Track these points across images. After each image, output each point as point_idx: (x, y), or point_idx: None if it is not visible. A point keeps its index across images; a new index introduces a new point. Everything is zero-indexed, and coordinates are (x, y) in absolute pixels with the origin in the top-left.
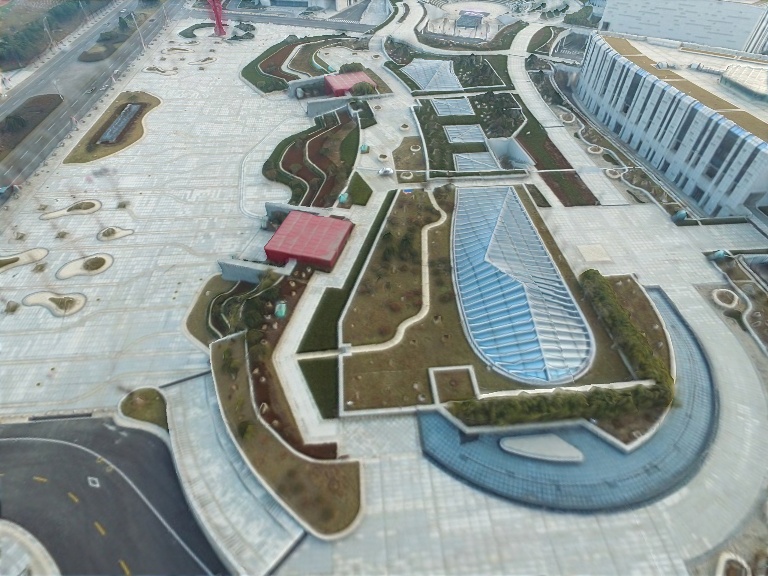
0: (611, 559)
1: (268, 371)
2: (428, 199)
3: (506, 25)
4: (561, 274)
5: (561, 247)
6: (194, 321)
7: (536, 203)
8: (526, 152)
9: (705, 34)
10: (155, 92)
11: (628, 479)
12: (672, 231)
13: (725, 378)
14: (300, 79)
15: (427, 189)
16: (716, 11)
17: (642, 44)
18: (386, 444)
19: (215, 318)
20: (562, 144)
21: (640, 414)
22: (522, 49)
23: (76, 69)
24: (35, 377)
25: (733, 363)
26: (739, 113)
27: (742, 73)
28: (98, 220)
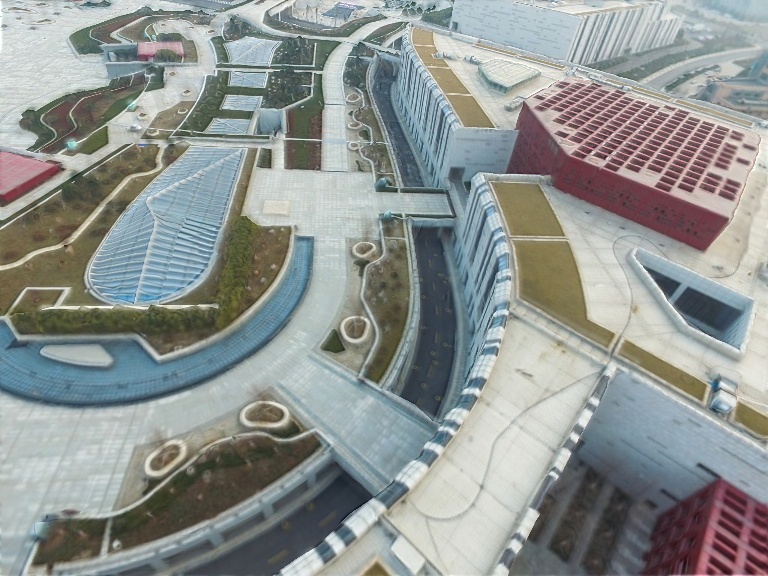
0: (68, 442)
1: None
2: (155, 153)
3: (362, 17)
4: (226, 221)
5: (247, 200)
6: None
7: (257, 164)
8: (286, 122)
9: (535, 39)
10: None
11: (141, 383)
12: (367, 195)
13: (306, 311)
14: None
15: (162, 145)
16: (542, 18)
17: (445, 38)
18: None
19: None
20: (329, 119)
21: (194, 333)
22: (360, 38)
23: None
24: None
25: (324, 300)
26: (465, 97)
27: (497, 66)
28: None
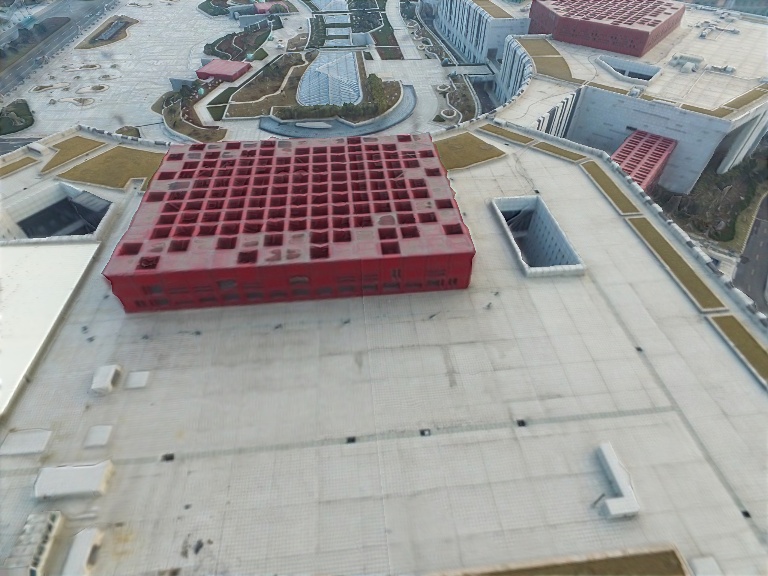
0: None
1: (190, 109)
2: (300, 57)
3: None
4: (360, 81)
5: (367, 73)
6: (155, 107)
7: (365, 58)
8: (373, 39)
9: None
10: (135, 17)
11: None
12: (438, 68)
13: (420, 110)
14: (237, 6)
15: (302, 54)
16: None
17: None
18: (243, 126)
19: (167, 103)
20: (400, 36)
21: (367, 116)
22: None
23: (77, 4)
24: (69, 124)
25: (428, 106)
26: (493, 7)
27: None
28: (99, 72)
